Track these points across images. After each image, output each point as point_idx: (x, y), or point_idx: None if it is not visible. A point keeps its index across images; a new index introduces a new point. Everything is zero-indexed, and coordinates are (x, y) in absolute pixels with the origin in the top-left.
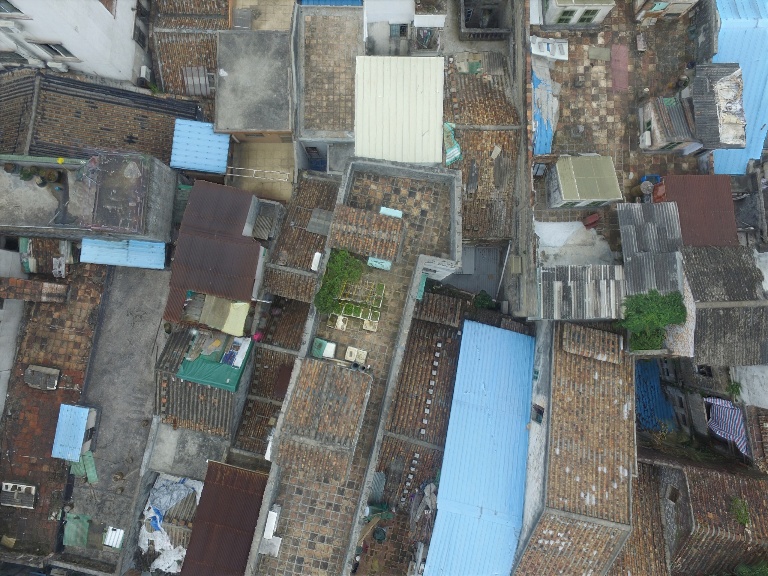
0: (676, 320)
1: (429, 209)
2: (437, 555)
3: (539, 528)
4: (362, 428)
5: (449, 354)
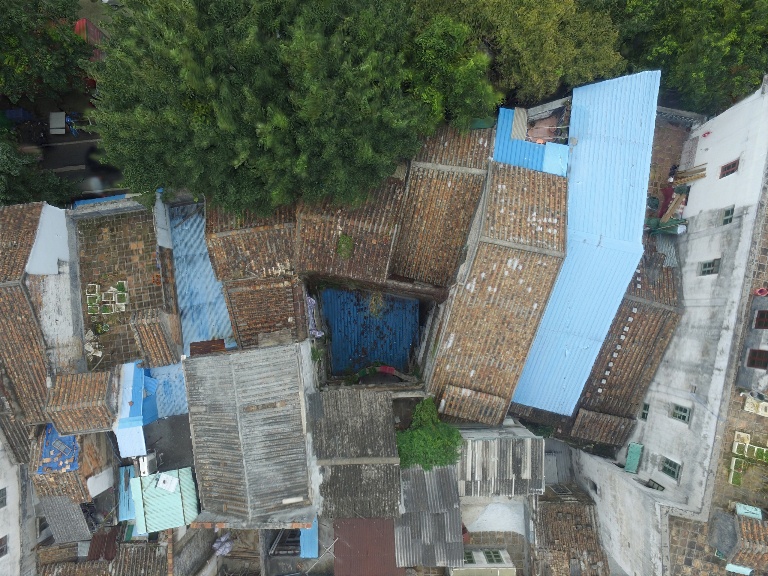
0: (403, 437)
1: (683, 567)
2: (637, 199)
3: (562, 235)
4: (744, 331)
5: (590, 381)
